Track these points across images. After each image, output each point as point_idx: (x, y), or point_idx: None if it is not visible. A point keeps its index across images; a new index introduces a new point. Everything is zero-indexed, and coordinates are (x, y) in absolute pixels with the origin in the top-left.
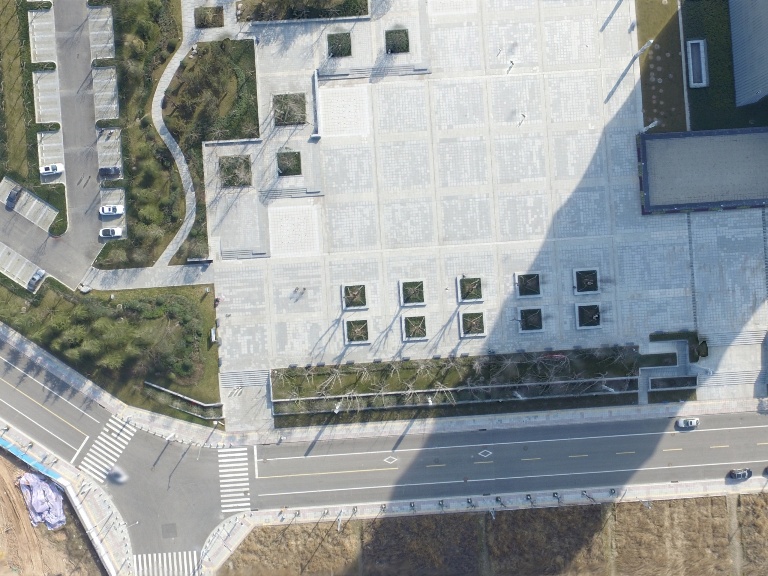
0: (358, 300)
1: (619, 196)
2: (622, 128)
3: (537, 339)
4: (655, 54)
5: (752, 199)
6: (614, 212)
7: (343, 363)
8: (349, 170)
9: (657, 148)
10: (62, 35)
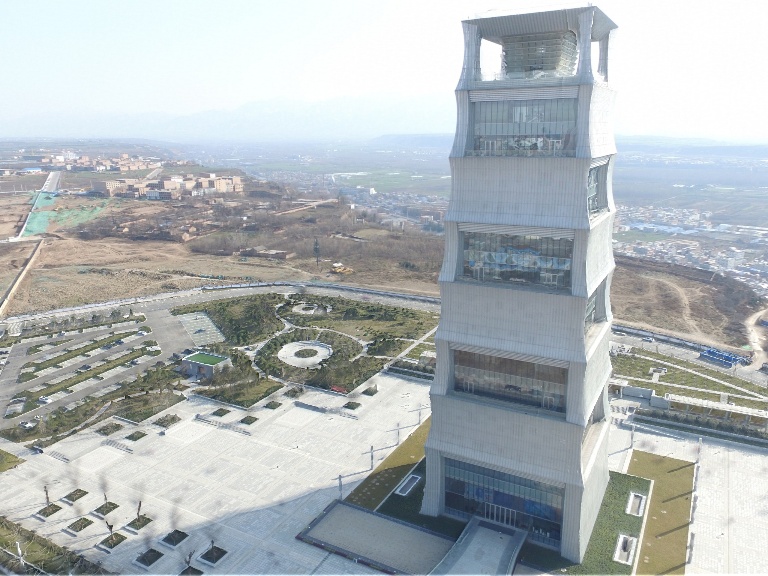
0: (75, 496)
1: (292, 523)
2: (331, 494)
3: (138, 573)
4: (386, 473)
5: (387, 565)
6: (279, 529)
7: (16, 522)
8: (159, 450)
9: (343, 510)
10: (121, 374)
